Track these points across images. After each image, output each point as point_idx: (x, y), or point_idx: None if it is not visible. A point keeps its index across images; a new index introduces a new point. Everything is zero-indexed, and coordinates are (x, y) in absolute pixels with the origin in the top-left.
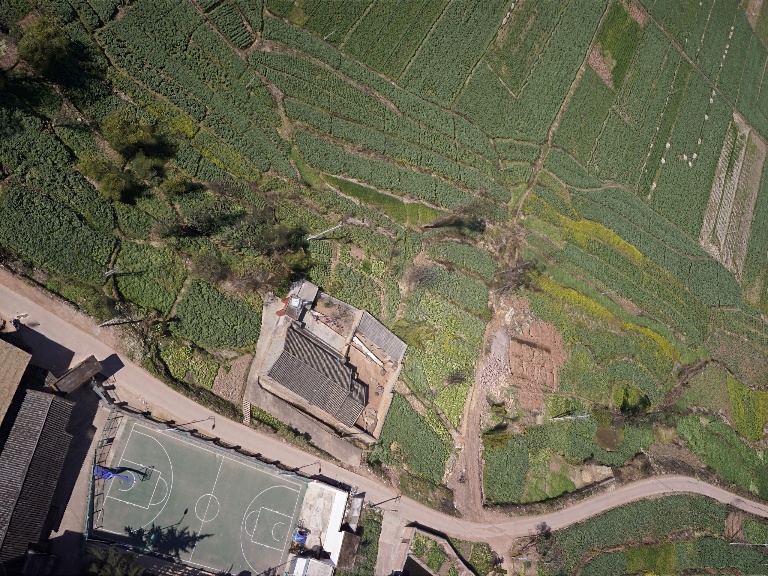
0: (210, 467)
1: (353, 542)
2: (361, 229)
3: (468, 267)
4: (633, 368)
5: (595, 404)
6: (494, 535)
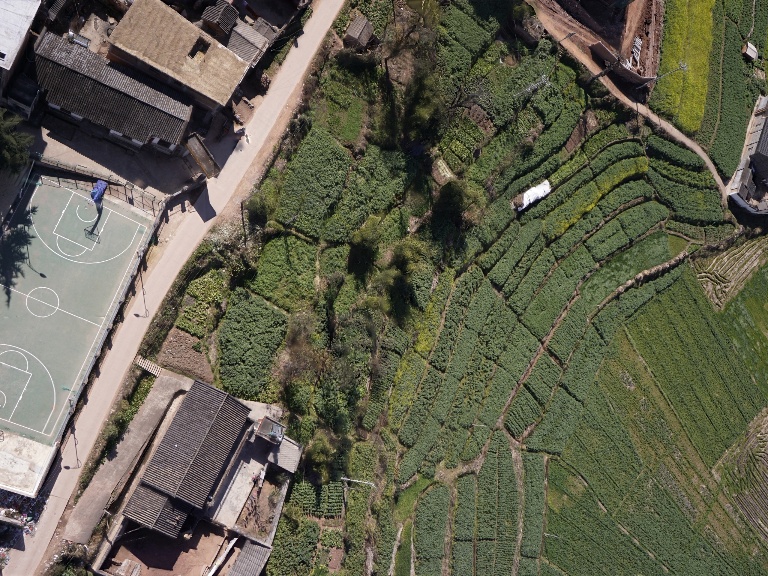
0: (91, 308)
1: None
2: (363, 569)
3: None
4: None
5: None
6: None
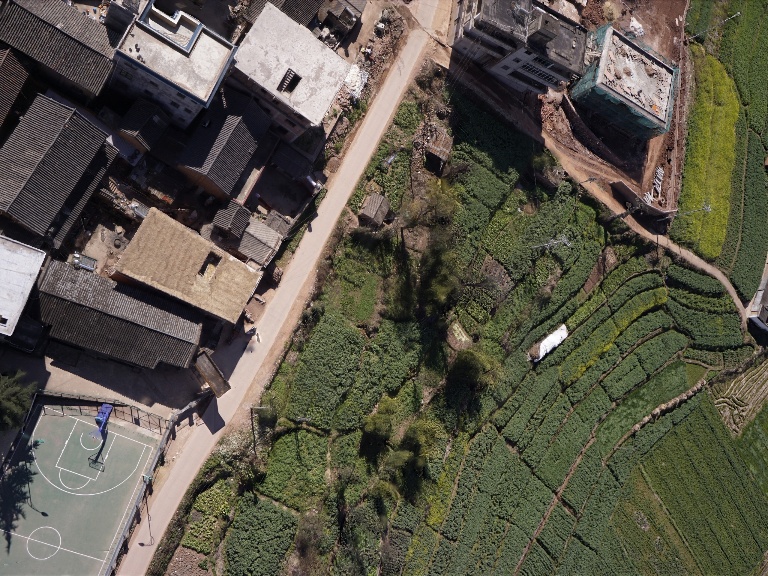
0: (94, 543)
1: None
2: None
3: None
4: None
5: None
6: None
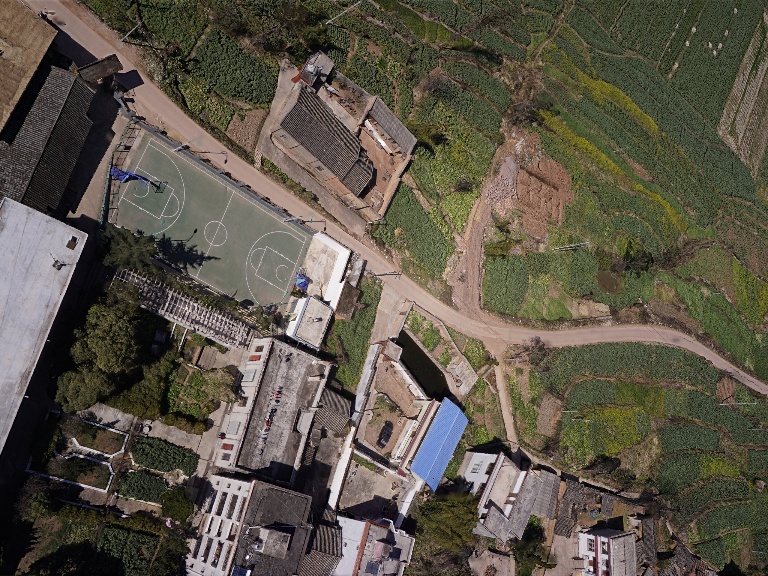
0: (220, 197)
1: (352, 294)
2: (380, 29)
3: (483, 93)
4: (639, 225)
5: (598, 247)
6: (489, 335)
